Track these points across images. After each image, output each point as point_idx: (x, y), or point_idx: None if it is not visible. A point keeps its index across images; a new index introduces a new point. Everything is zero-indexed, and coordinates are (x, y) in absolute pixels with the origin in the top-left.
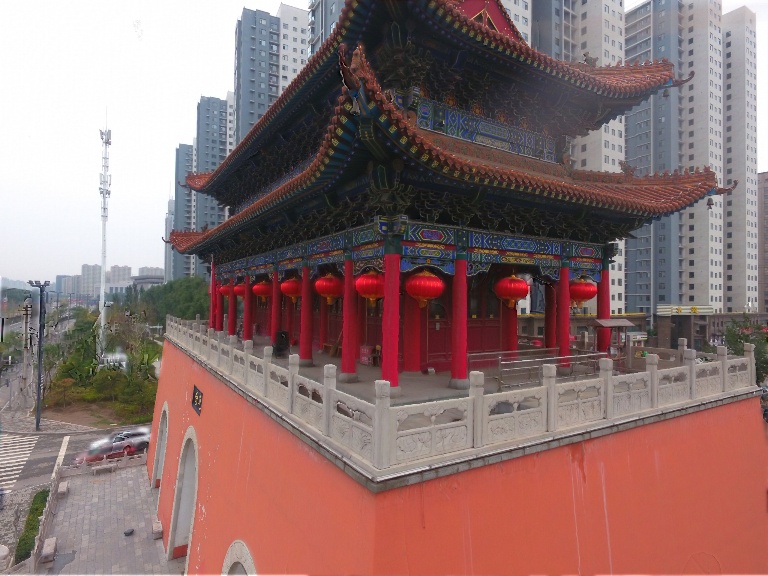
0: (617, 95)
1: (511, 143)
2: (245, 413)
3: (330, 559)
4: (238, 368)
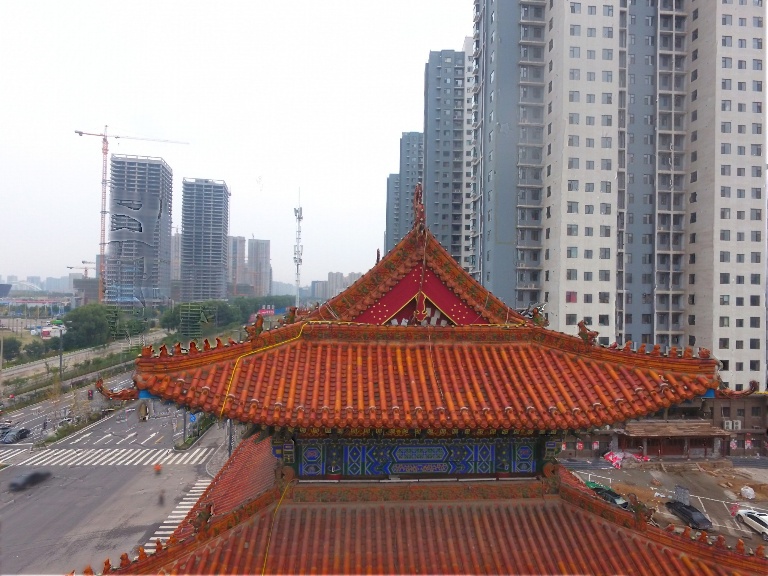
0: (591, 429)
1: (451, 462)
2: None
3: None
4: None
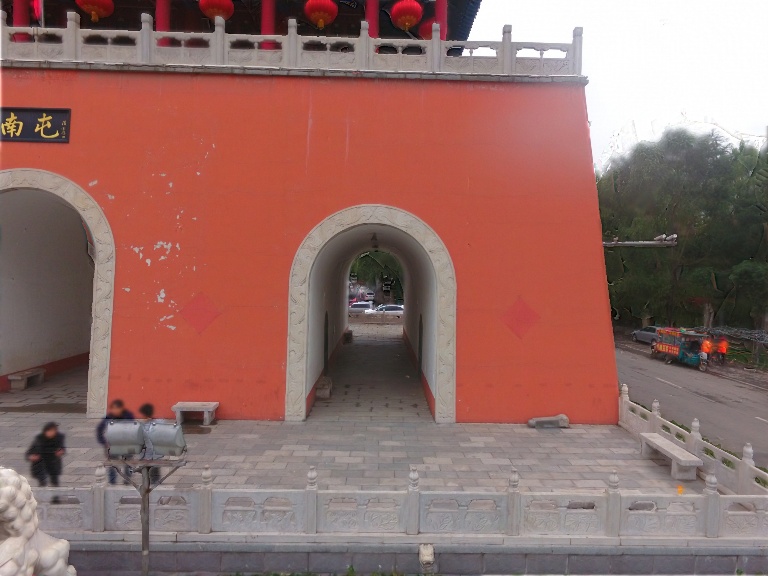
0: None
1: None
2: (312, 94)
3: (538, 141)
4: (254, 54)
